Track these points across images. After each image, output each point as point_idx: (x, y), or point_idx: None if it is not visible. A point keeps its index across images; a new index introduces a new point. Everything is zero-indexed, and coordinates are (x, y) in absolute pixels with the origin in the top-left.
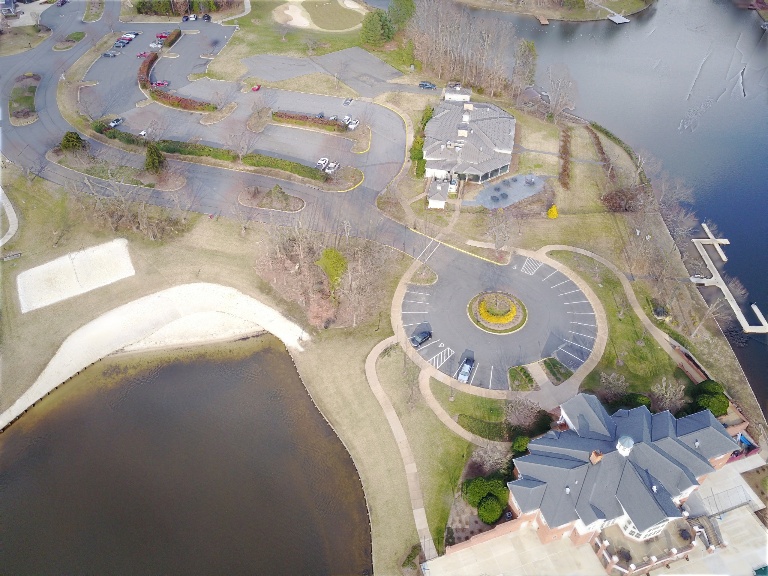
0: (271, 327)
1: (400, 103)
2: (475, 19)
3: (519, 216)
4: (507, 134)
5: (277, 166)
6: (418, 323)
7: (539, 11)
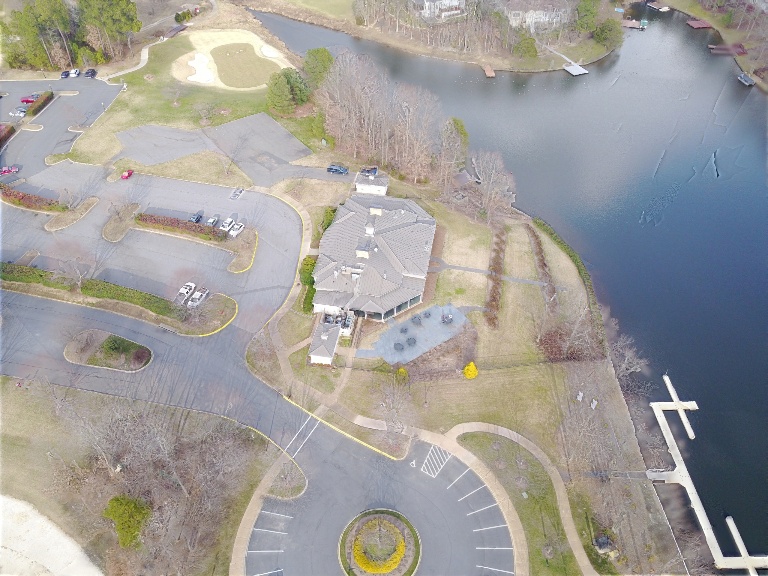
0: (65, 575)
1: (301, 195)
2: (398, 85)
3: (427, 375)
4: (422, 249)
5: (124, 299)
6: (267, 572)
7: (485, 59)
